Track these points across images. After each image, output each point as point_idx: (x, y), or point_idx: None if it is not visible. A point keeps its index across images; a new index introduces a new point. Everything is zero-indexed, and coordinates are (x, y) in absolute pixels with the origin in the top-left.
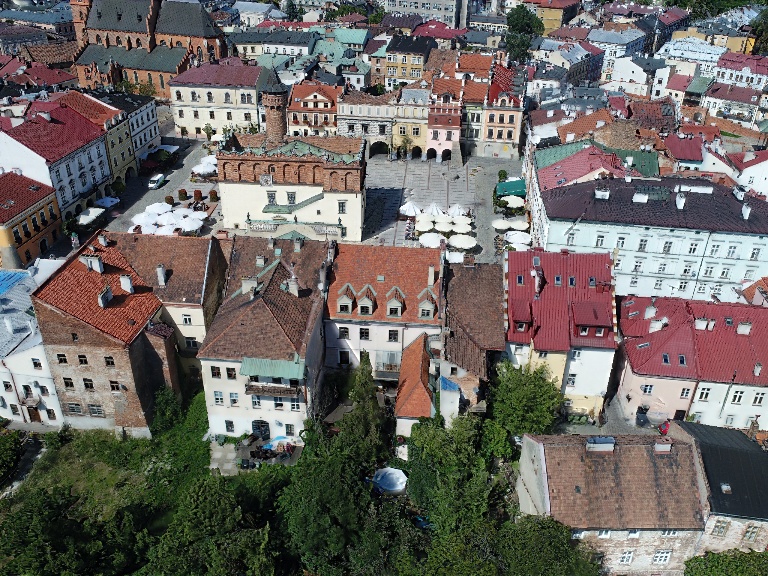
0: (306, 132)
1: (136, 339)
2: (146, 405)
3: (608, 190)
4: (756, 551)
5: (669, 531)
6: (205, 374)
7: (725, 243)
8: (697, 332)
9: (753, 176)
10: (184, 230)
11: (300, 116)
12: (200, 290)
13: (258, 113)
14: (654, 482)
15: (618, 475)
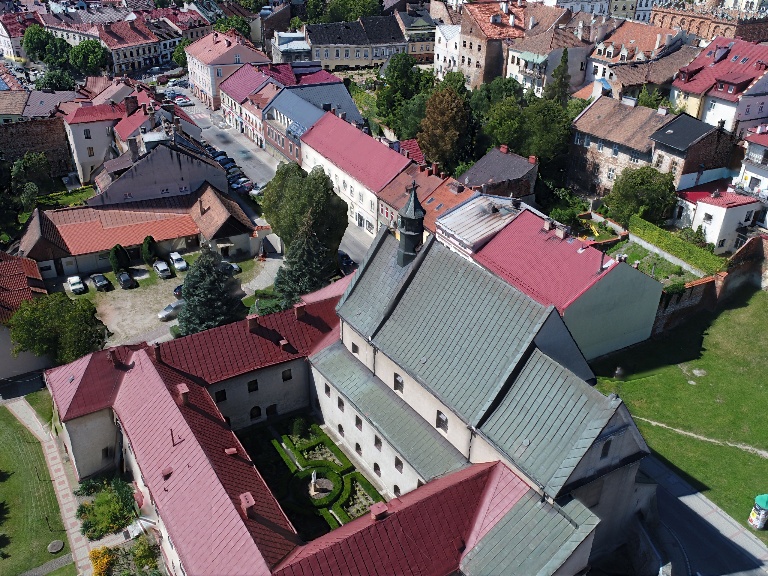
0: None
1: (495, 41)
2: (486, 81)
3: None
4: (672, 181)
5: (635, 158)
6: (509, 60)
7: None
8: None
9: None
10: None
11: None
12: None
13: None
14: None
15: (626, 117)
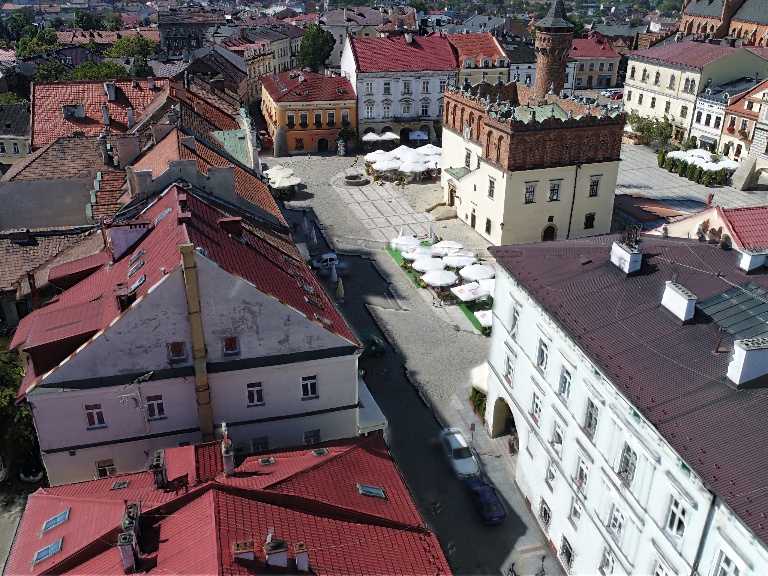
0: (740, 148)
1: None
2: None
3: (633, 249)
4: None
5: None
6: None
7: (751, 573)
8: None
9: None
10: (399, 168)
11: (738, 122)
12: None
13: (695, 108)
14: None
15: None
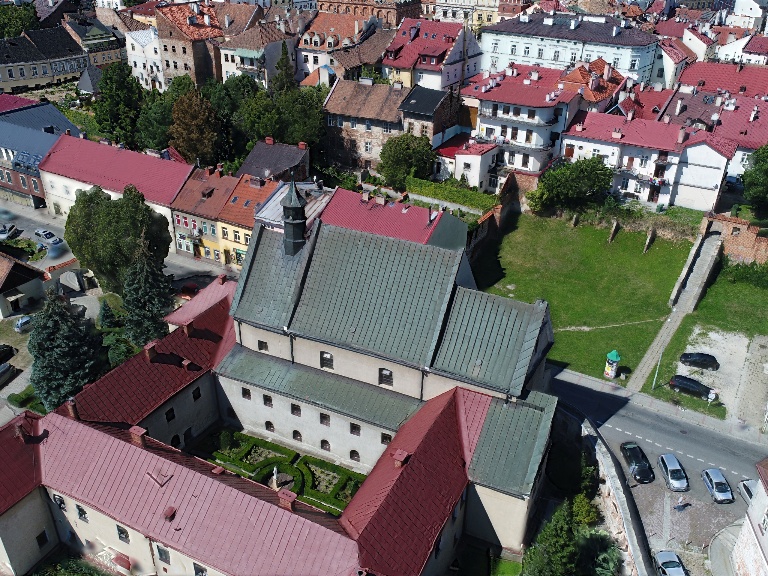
0: None
1: (199, 42)
2: (200, 82)
3: (528, 15)
4: None
5: (387, 129)
6: (222, 59)
7: (594, 53)
8: (506, 77)
9: (728, 54)
10: None
11: None
12: (243, 30)
13: None
14: (384, 100)
15: (368, 95)
